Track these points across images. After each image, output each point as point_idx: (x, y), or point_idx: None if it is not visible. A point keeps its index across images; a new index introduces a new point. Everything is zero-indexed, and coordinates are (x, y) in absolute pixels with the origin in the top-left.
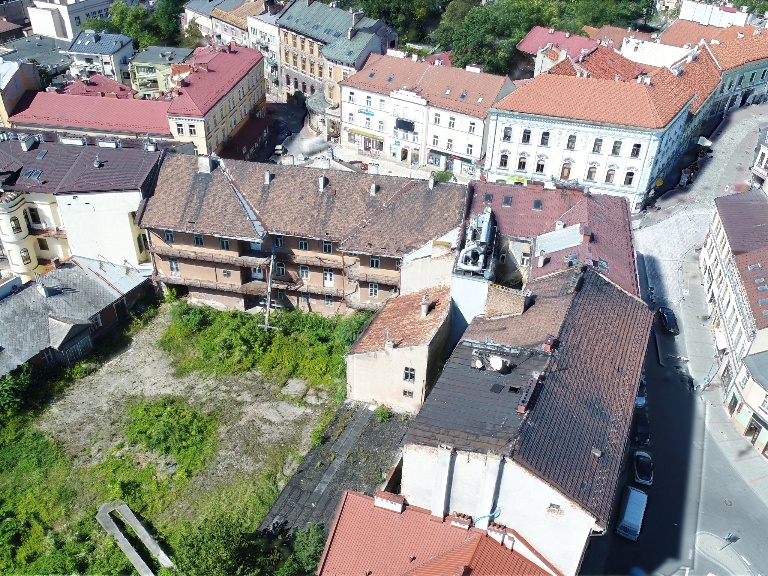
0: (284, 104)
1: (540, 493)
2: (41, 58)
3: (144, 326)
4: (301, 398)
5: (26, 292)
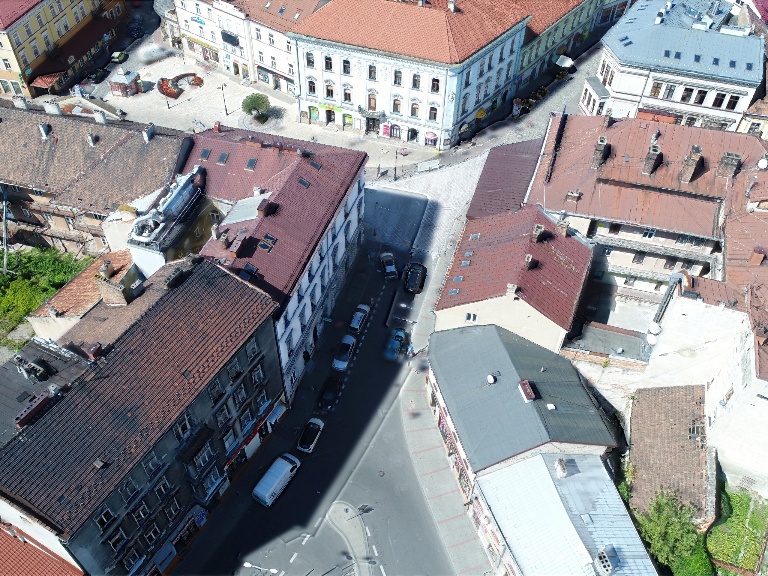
0: None
1: (7, 507)
2: None
3: None
4: (23, 344)
5: None
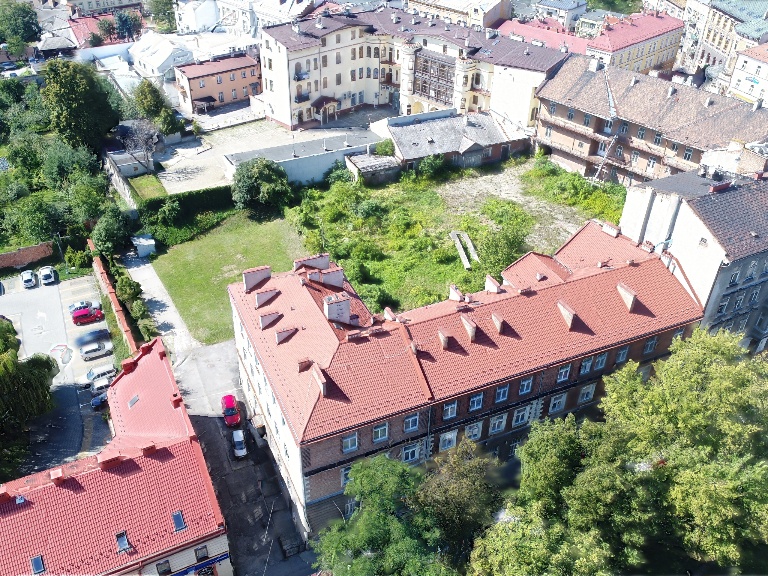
0: (692, 75)
1: (697, 228)
2: (517, 10)
3: (515, 166)
4: None
5: (457, 119)
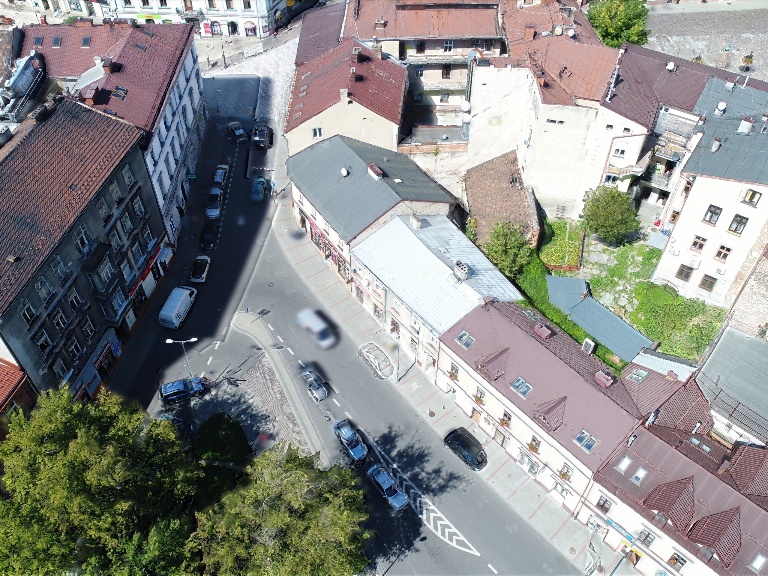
0: None
1: None
2: None
3: None
4: None
5: None
